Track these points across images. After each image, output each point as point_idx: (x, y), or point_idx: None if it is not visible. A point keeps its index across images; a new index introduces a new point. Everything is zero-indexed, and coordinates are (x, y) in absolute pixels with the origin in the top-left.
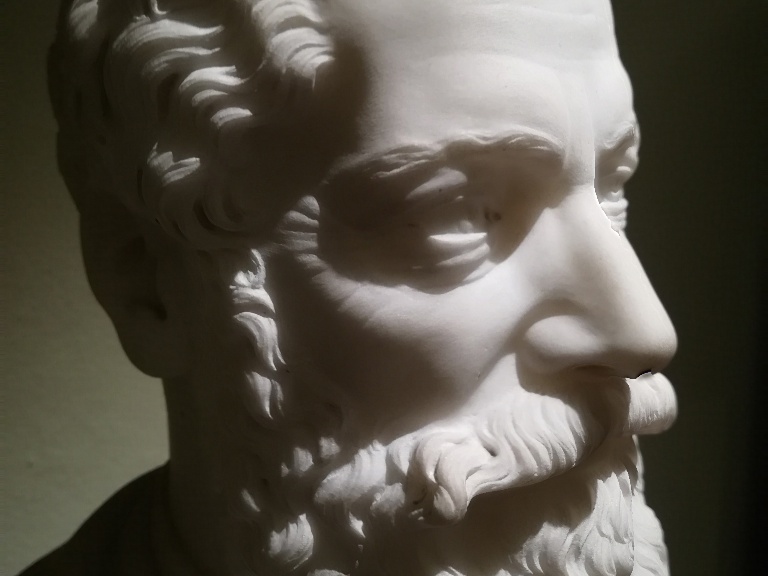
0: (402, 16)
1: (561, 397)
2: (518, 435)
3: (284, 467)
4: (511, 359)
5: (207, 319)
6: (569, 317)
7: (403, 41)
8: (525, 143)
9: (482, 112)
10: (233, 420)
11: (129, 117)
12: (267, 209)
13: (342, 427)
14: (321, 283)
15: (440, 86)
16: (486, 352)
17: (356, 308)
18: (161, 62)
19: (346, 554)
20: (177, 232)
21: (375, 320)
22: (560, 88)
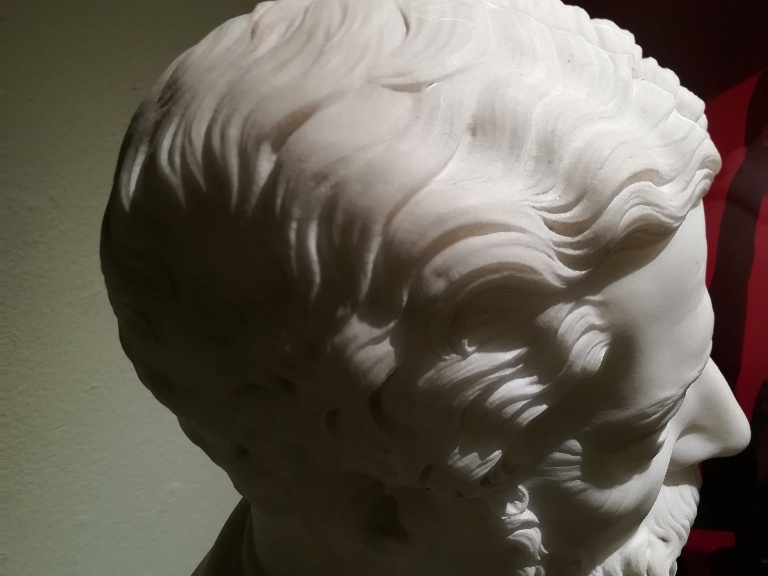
0: (660, 304)
1: (687, 483)
2: (677, 523)
3: None
4: None
5: (466, 538)
6: (695, 434)
7: (659, 322)
8: None
9: (700, 353)
10: None
11: (427, 433)
12: (533, 456)
13: None
14: (586, 498)
15: (679, 346)
16: None
17: (612, 507)
18: (475, 391)
19: None
20: (457, 496)
21: (623, 508)
22: None
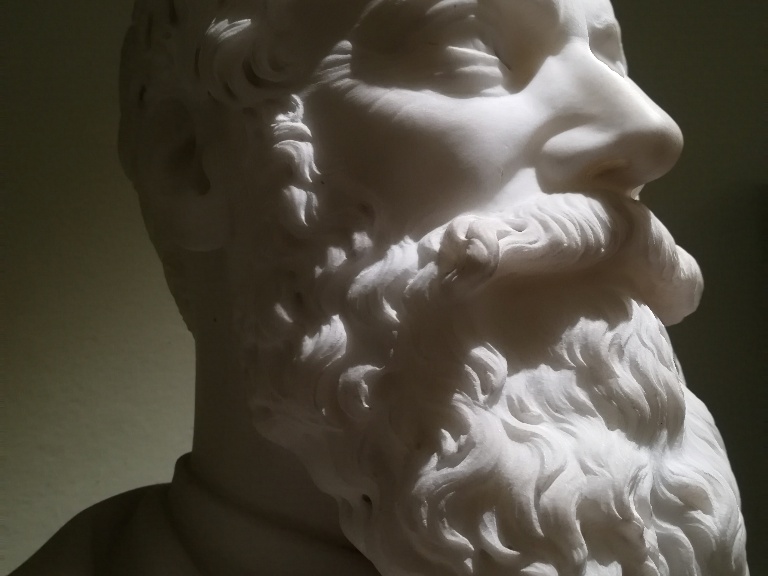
0: None
1: (582, 193)
2: (544, 213)
3: (318, 269)
4: (531, 172)
5: (248, 168)
6: (580, 127)
7: None
8: None
9: None
10: (269, 243)
11: (193, 8)
12: (306, 61)
13: (374, 224)
14: (354, 95)
15: None
16: (506, 150)
17: (385, 106)
18: None
19: (380, 347)
20: (226, 92)
21: (403, 114)
22: None
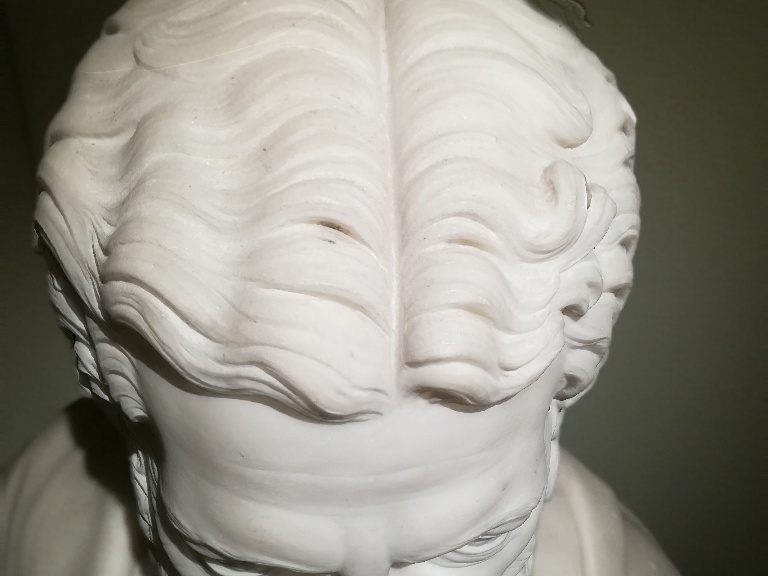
0: (181, 436)
1: None
2: None
3: None
4: None
5: None
6: None
7: (182, 451)
8: (274, 566)
9: (231, 538)
10: None
11: None
12: None
13: None
14: None
15: (204, 500)
16: None
17: None
18: (61, 321)
19: None
20: None
21: None
22: (336, 531)
